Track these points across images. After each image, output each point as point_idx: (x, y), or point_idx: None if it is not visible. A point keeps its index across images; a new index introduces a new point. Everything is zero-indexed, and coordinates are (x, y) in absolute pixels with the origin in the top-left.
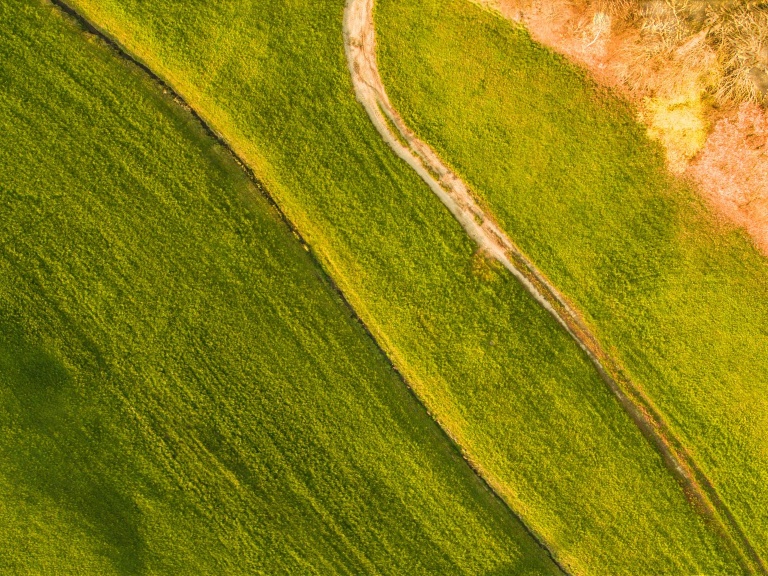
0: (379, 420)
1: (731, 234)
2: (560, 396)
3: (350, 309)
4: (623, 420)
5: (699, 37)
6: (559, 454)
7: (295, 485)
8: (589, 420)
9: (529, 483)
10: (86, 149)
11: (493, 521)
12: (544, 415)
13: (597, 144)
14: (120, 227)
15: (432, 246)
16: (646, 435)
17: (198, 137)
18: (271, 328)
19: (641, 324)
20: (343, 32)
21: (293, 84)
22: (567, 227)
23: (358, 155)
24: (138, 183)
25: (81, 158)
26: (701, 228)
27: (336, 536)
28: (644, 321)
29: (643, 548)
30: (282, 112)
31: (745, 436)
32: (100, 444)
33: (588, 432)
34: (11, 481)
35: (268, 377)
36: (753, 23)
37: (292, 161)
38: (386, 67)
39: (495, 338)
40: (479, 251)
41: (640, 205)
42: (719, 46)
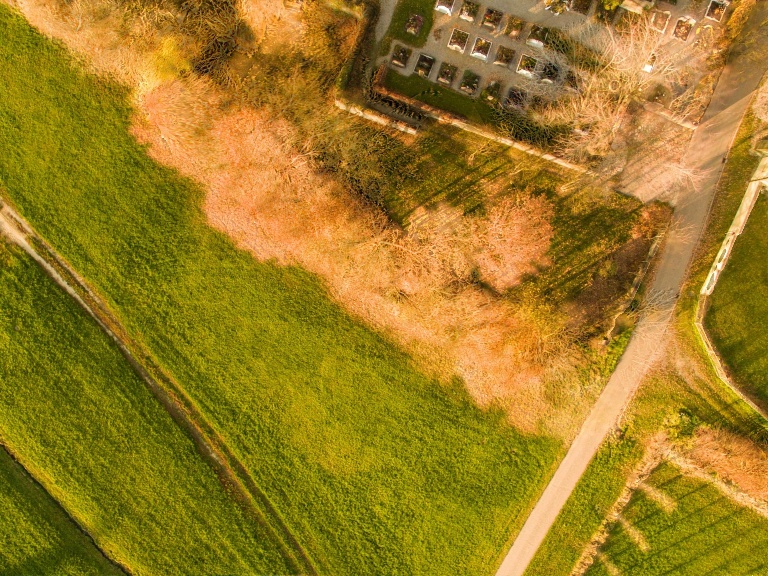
0: None
1: (242, 219)
2: (88, 382)
3: None
4: (154, 406)
5: (177, 20)
6: (91, 440)
7: None
8: (119, 406)
9: (64, 469)
10: None
11: (31, 506)
12: (74, 401)
13: (104, 129)
14: None
15: None
16: (178, 421)
17: None
18: None
19: (165, 310)
20: None
21: None
22: (84, 212)
23: None
24: None
25: None
26: (214, 213)
27: None
28: (167, 307)
29: (181, 535)
30: None
31: (275, 423)
32: None
33: (119, 418)
34: None
35: None
36: (230, 6)
37: None
38: None
39: (20, 323)
40: None
41: (152, 190)
42: (197, 29)
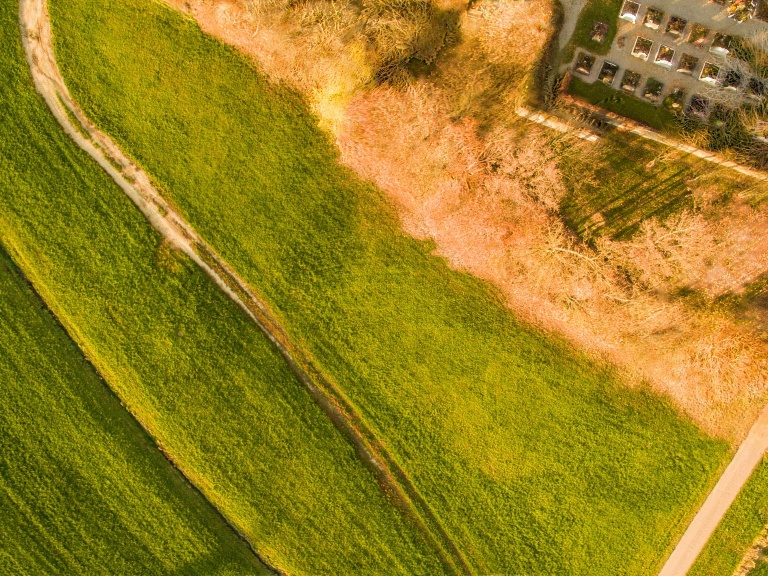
0: (72, 411)
1: (410, 225)
2: (250, 387)
3: (41, 300)
4: (315, 412)
5: (356, 27)
6: (252, 445)
7: None
8: (281, 412)
9: (224, 474)
10: None
11: (189, 512)
12: (235, 406)
13: (274, 135)
14: None
15: (117, 237)
16: (339, 427)
17: None
18: None
19: (328, 316)
20: (20, 24)
21: None
22: (250, 218)
23: (40, 147)
24: None
25: None
26: (381, 219)
27: (34, 526)
28: (331, 313)
29: (340, 540)
30: None
31: (437, 428)
32: None
33: (280, 424)
34: None
35: None
36: (410, 13)
37: None
38: (64, 59)
39: (183, 329)
40: (164, 242)
41: (320, 196)
42: (377, 36)
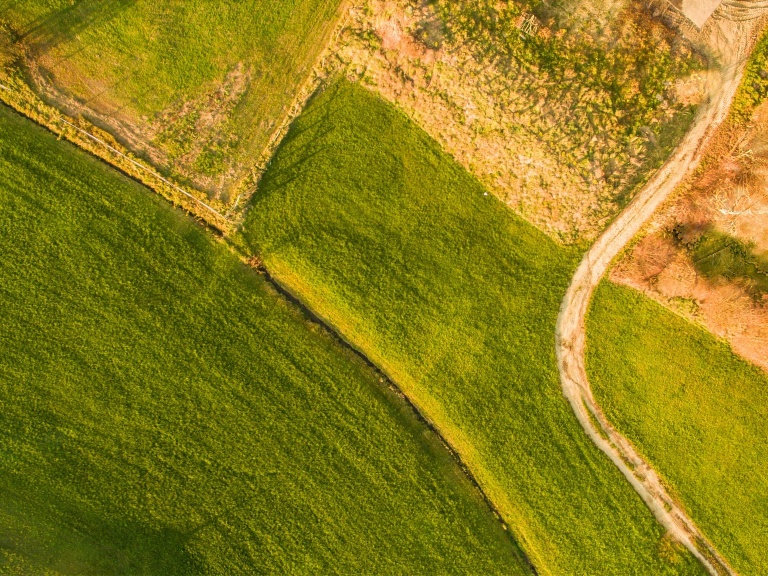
0: None
1: None
2: None
3: None
4: None
5: None
6: None
7: None
8: None
9: None
10: (302, 431)
11: None
12: None
13: None
14: (330, 504)
15: (623, 529)
16: None
17: (410, 423)
18: None
19: None
20: (555, 334)
21: (504, 379)
22: (749, 517)
23: (560, 445)
24: (350, 464)
25: (297, 439)
26: None
27: None
28: None
29: None
30: (492, 404)
31: None
32: None
33: None
34: None
35: None
36: None
37: (498, 448)
38: (593, 367)
39: None
40: (666, 535)
41: None
42: None
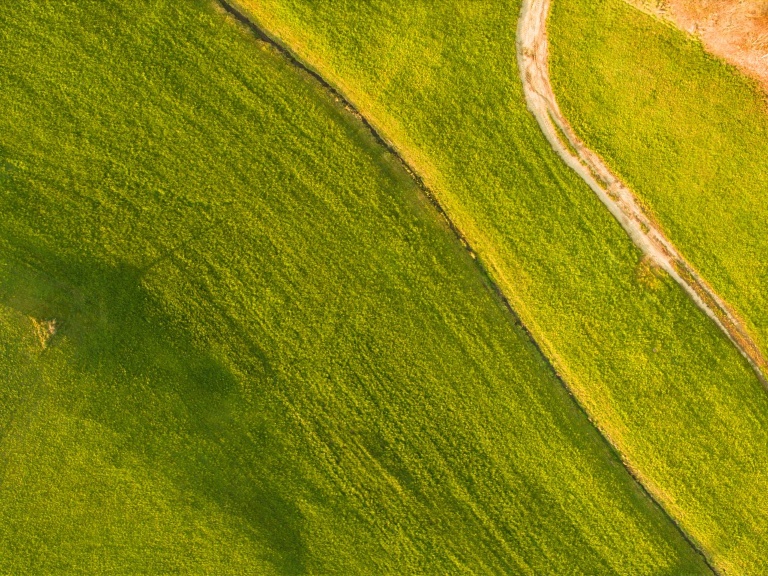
0: (541, 426)
1: None
2: (721, 403)
3: (514, 316)
4: None
5: None
6: (718, 460)
7: (456, 490)
8: (748, 427)
9: (687, 489)
10: (257, 156)
11: (651, 526)
12: (704, 422)
13: (765, 154)
14: (289, 234)
15: (598, 254)
16: None
17: (369, 145)
18: (437, 335)
19: None
20: (516, 42)
21: (465, 93)
22: (732, 236)
23: (527, 164)
24: (308, 190)
25: (252, 165)
26: None
27: (496, 541)
28: None
29: None
30: (453, 121)
31: None
32: (265, 449)
33: (747, 438)
34: (177, 486)
35: (432, 383)
36: None
37: (462, 169)
38: (558, 77)
39: (658, 345)
40: (644, 259)
41: None
42: None
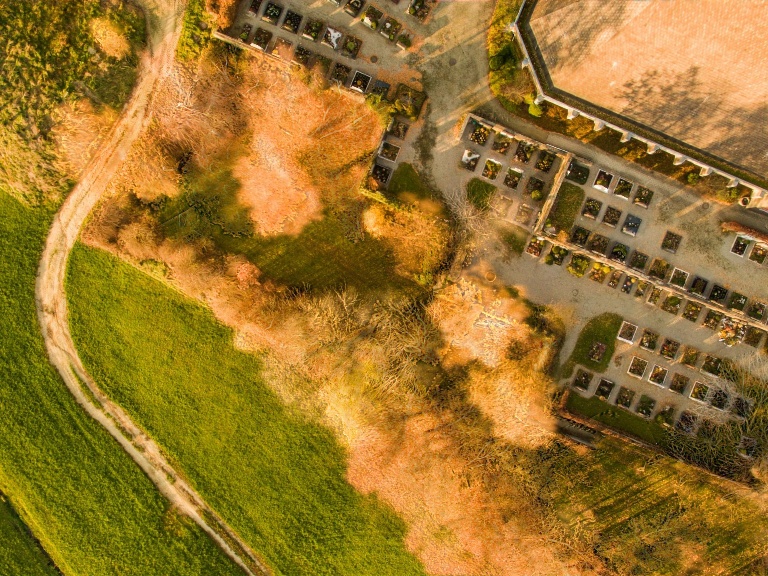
0: None
1: (411, 503)
2: None
3: (47, 557)
4: None
5: (367, 331)
6: None
7: None
8: None
9: None
10: None
11: None
12: None
13: (282, 415)
14: None
15: (126, 502)
16: None
17: None
18: None
19: None
20: (36, 299)
21: None
22: (256, 489)
23: (52, 415)
24: None
25: None
26: (383, 496)
27: None
28: None
29: None
30: None
31: None
32: None
33: None
34: None
35: None
36: (419, 319)
37: None
38: (78, 334)
39: None
40: (171, 508)
41: (325, 472)
42: (386, 340)
